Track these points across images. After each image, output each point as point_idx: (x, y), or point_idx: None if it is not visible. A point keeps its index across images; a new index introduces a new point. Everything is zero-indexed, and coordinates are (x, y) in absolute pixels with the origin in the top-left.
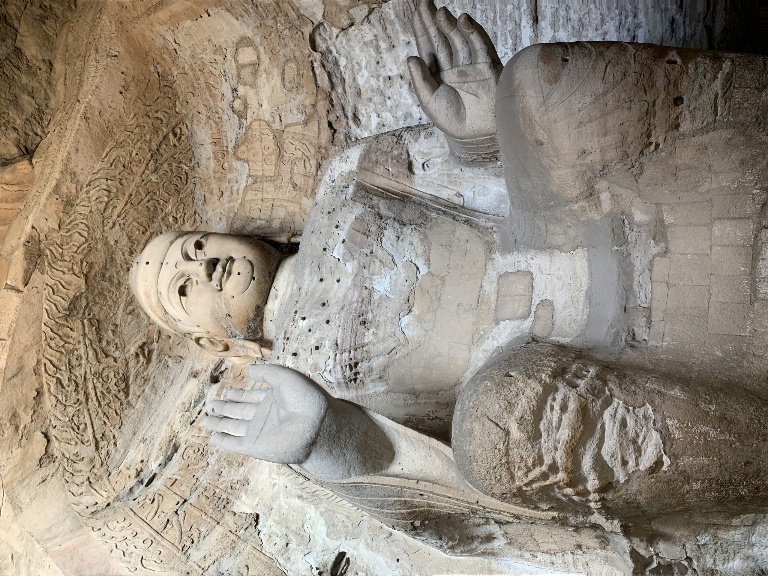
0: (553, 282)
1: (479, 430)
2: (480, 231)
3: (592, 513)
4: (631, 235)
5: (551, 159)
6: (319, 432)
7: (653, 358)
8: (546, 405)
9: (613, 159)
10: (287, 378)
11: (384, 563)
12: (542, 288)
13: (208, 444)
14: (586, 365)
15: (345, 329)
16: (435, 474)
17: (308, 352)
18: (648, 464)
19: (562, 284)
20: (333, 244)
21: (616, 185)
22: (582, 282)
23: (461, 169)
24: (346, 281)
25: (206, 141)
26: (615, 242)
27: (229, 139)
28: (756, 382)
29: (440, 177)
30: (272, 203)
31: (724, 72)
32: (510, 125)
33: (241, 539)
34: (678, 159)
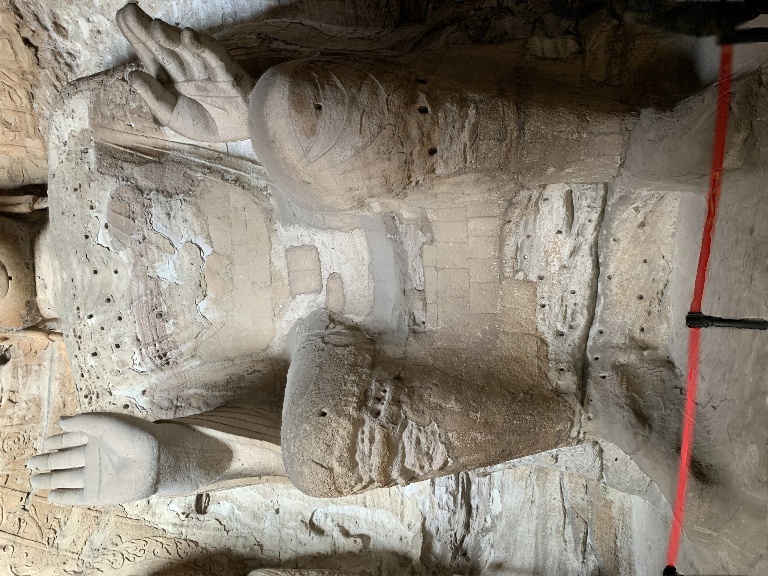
0: (338, 256)
1: (308, 472)
2: (255, 195)
3: None
4: (402, 227)
5: (320, 191)
6: (159, 471)
7: (432, 348)
8: (358, 439)
9: (379, 193)
10: (107, 429)
11: (240, 489)
12: (329, 262)
13: (27, 431)
14: (382, 383)
15: (142, 324)
16: (273, 465)
17: (109, 350)
18: (438, 466)
19: (346, 258)
20: (95, 230)
21: (384, 199)
22: (364, 256)
23: None
24: (125, 272)
25: None
26: (388, 232)
27: None
28: (506, 367)
29: None
30: None
31: (470, 123)
32: (272, 166)
33: (102, 513)
34: (436, 190)
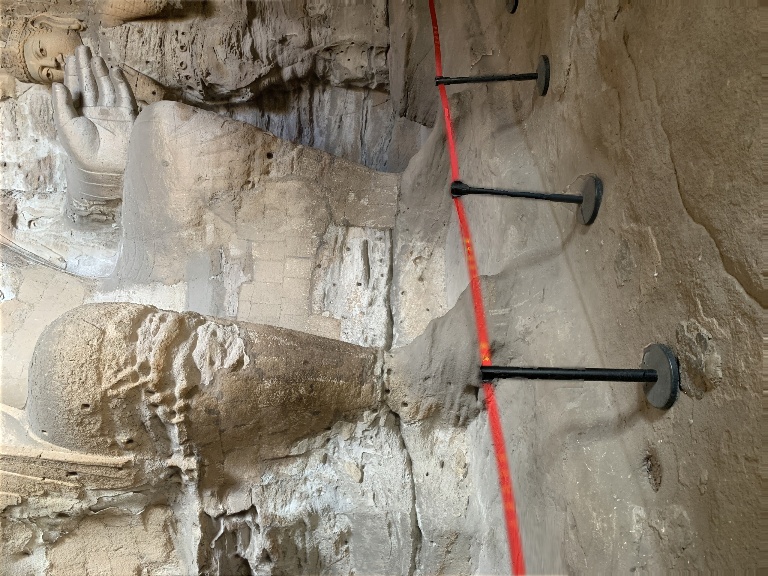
0: None
1: (72, 330)
2: (82, 279)
3: (170, 457)
4: (226, 267)
5: (172, 181)
6: None
7: None
8: (146, 318)
9: (221, 189)
10: None
11: None
12: None
13: None
14: None
15: None
16: None
17: None
18: (232, 362)
19: None
20: None
21: (220, 218)
22: (179, 311)
23: (72, 233)
24: None
25: None
26: (213, 272)
27: None
28: None
29: (46, 237)
30: None
31: (298, 148)
32: (143, 145)
33: None
34: (266, 199)
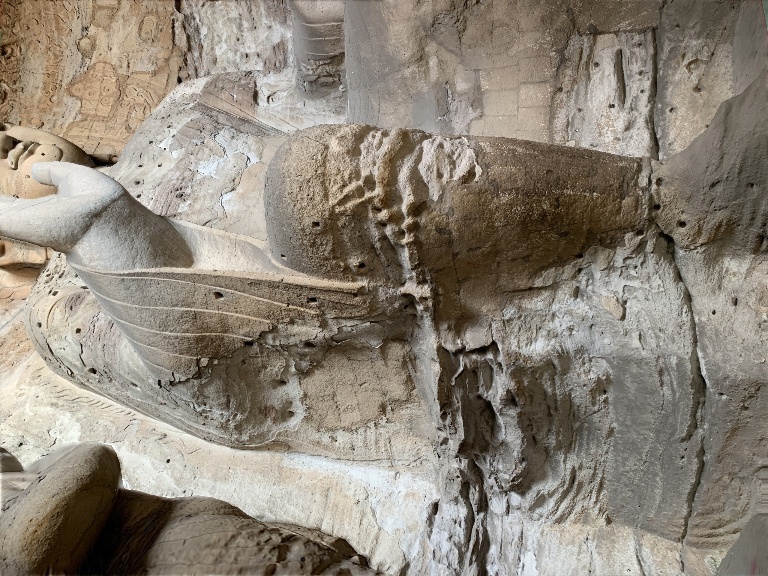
0: None
1: (297, 147)
2: None
3: (403, 285)
4: (453, 104)
5: (390, 10)
6: (107, 208)
7: None
8: (368, 135)
9: (442, 10)
10: (80, 167)
11: (149, 464)
12: None
13: None
14: None
15: (158, 201)
16: (237, 270)
17: None
18: (462, 173)
19: None
20: (162, 138)
21: (443, 48)
22: None
23: (304, 103)
24: (169, 165)
25: (39, 71)
26: (439, 112)
27: (66, 74)
28: None
29: (283, 111)
30: (99, 141)
31: None
32: None
33: None
34: (494, 14)
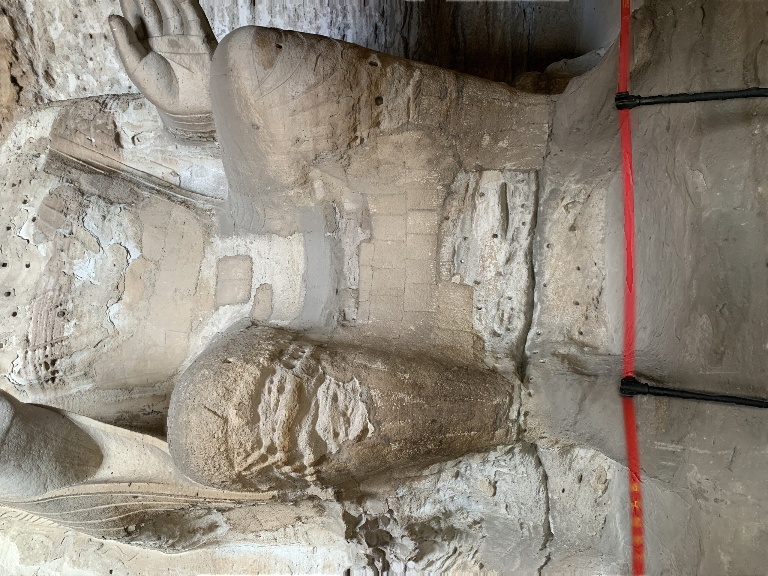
0: (272, 266)
1: (196, 421)
2: (198, 213)
3: (309, 486)
4: (341, 222)
5: (267, 144)
6: (3, 446)
7: (360, 335)
8: (264, 388)
9: (324, 149)
10: None
11: None
12: (261, 272)
13: None
14: (302, 346)
15: (38, 322)
16: (150, 473)
17: None
18: (356, 433)
19: (280, 268)
20: (20, 222)
21: (328, 174)
22: (299, 266)
23: (176, 146)
24: (38, 266)
25: None
26: (328, 228)
27: None
28: (440, 351)
29: (153, 153)
30: None
31: (415, 80)
32: (225, 105)
33: None
34: (379, 154)
